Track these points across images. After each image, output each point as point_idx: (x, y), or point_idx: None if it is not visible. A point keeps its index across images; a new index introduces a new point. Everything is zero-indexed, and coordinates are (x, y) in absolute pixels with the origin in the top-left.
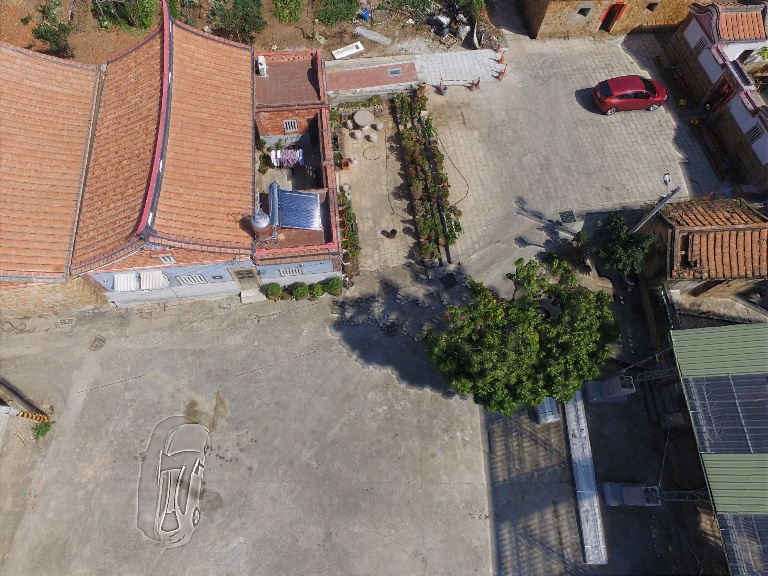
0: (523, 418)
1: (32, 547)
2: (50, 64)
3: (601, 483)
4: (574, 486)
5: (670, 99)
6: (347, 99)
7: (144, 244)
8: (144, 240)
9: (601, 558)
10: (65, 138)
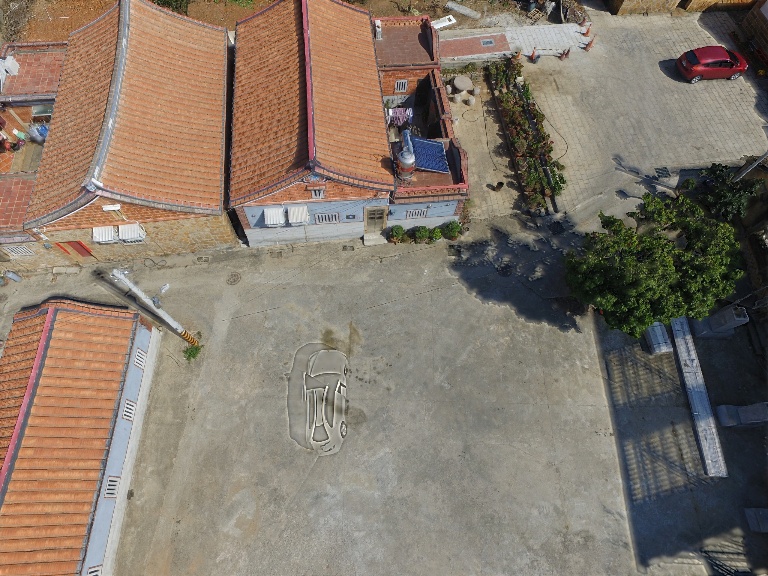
0: (636, 350)
1: (196, 453)
2: (186, 23)
3: (715, 407)
4: (690, 409)
5: (748, 70)
6: (445, 66)
7: (309, 174)
8: (310, 169)
9: (722, 471)
10: (205, 89)
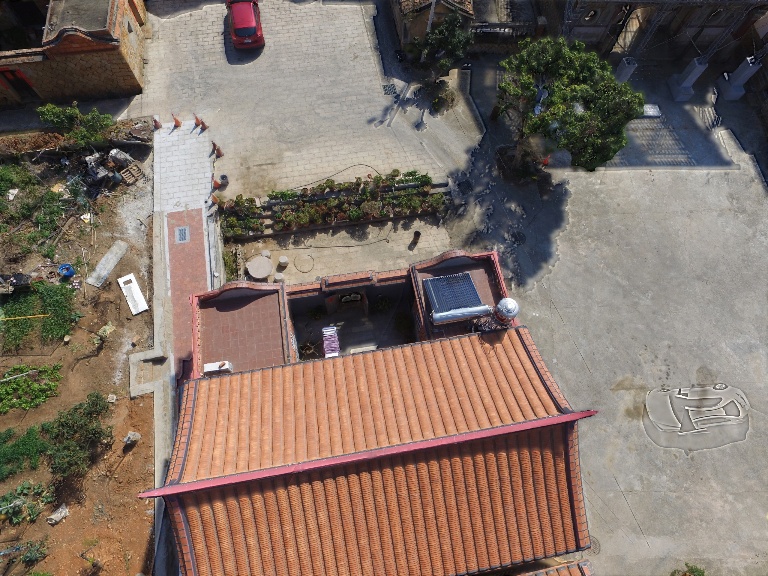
0: None
1: None
2: None
3: None
4: None
5: None
6: None
7: None
8: None
9: (656, 108)
10: None
